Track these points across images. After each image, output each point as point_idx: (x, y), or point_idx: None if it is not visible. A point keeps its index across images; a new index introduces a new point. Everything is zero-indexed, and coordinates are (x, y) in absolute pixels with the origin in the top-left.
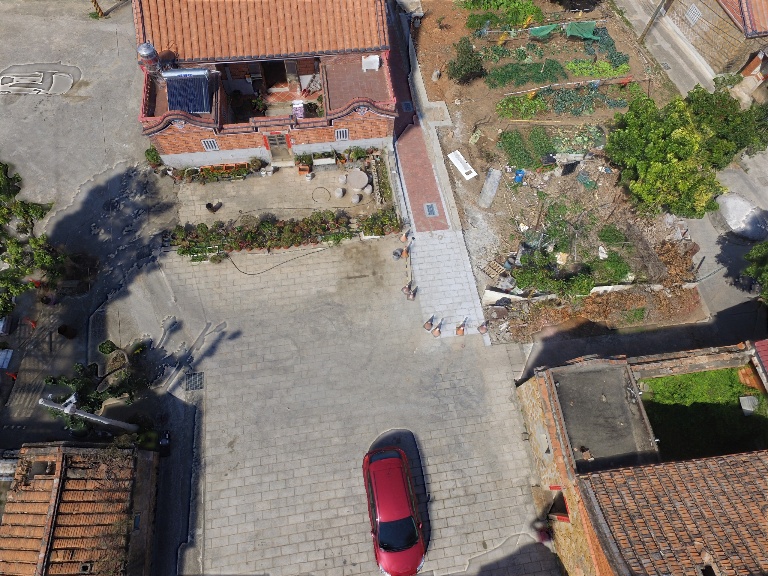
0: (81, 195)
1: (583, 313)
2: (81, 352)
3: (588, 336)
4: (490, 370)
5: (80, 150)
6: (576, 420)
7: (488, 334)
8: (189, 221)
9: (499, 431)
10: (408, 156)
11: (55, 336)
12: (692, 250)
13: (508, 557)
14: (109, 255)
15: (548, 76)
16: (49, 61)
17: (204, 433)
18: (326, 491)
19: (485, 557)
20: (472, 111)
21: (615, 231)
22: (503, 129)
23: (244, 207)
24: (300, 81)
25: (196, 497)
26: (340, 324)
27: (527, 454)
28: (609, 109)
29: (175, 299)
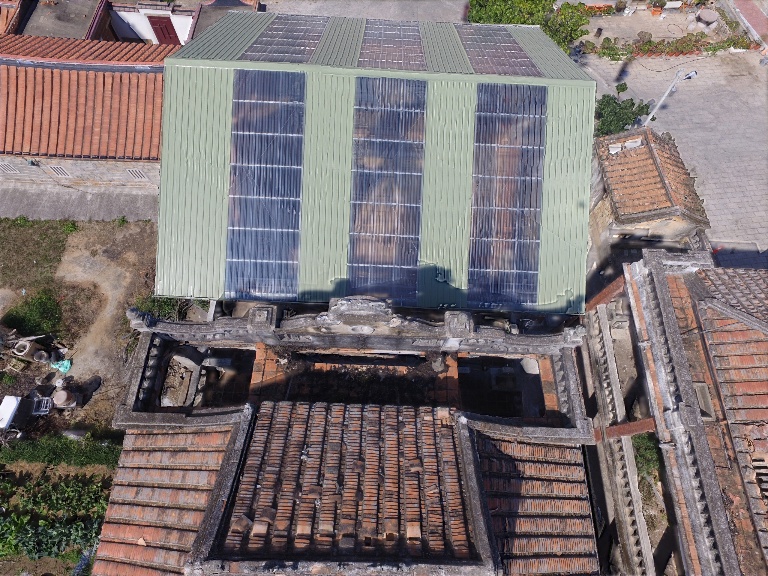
0: None
1: None
2: None
3: None
4: None
5: None
6: None
7: None
8: None
9: None
10: (739, 2)
11: None
12: None
13: None
14: None
15: None
16: None
17: None
18: None
19: None
20: None
21: None
22: None
23: (619, 35)
24: None
25: None
26: (739, 103)
27: None
28: None
29: (608, 84)
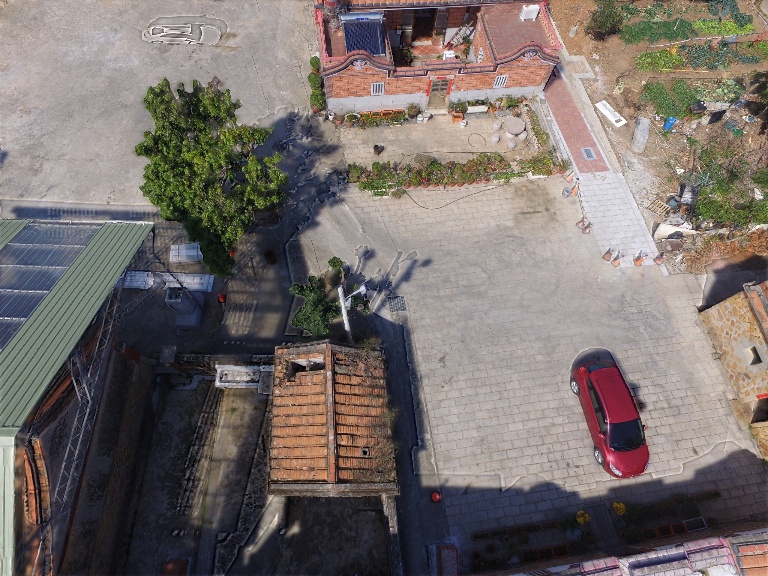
0: None
1: (750, 247)
2: (284, 276)
3: (756, 269)
4: (672, 297)
5: (240, 96)
6: None
7: (664, 265)
8: (356, 162)
9: (690, 351)
10: (557, 105)
11: (256, 262)
12: None
13: (719, 462)
14: (290, 191)
15: (680, 33)
16: (194, 14)
17: (415, 350)
18: (539, 402)
19: (697, 461)
20: (611, 65)
21: None
22: (645, 81)
23: (406, 151)
24: (445, 34)
25: (419, 406)
26: (524, 254)
27: (720, 372)
28: (741, 65)
29: (363, 230)
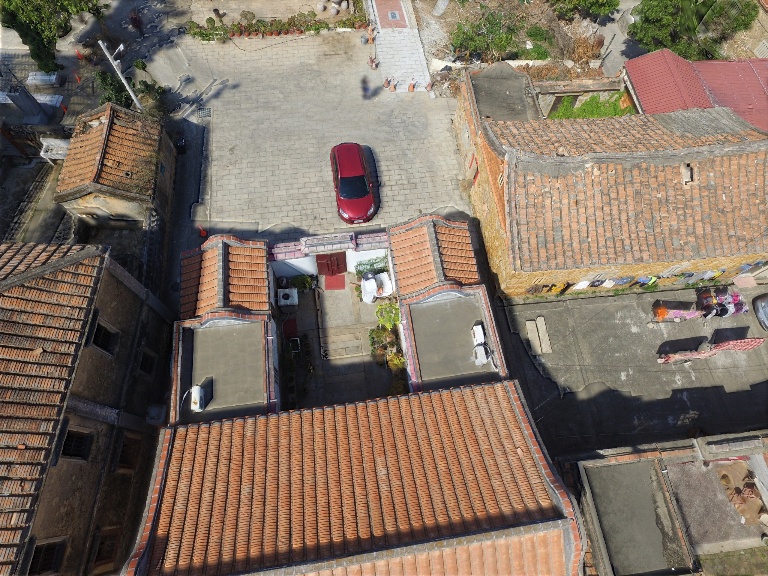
0: (113, 4)
1: None
2: None
3: None
4: (433, 113)
5: None
6: (485, 102)
7: (433, 91)
8: (200, 24)
9: (437, 148)
10: None
11: (96, 84)
12: (599, 39)
13: None
14: (136, 39)
15: None
16: None
17: (211, 142)
18: (303, 178)
19: None
20: None
21: (540, 29)
22: None
23: None
24: None
25: (205, 178)
26: (317, 82)
27: (457, 162)
28: None
29: (189, 65)
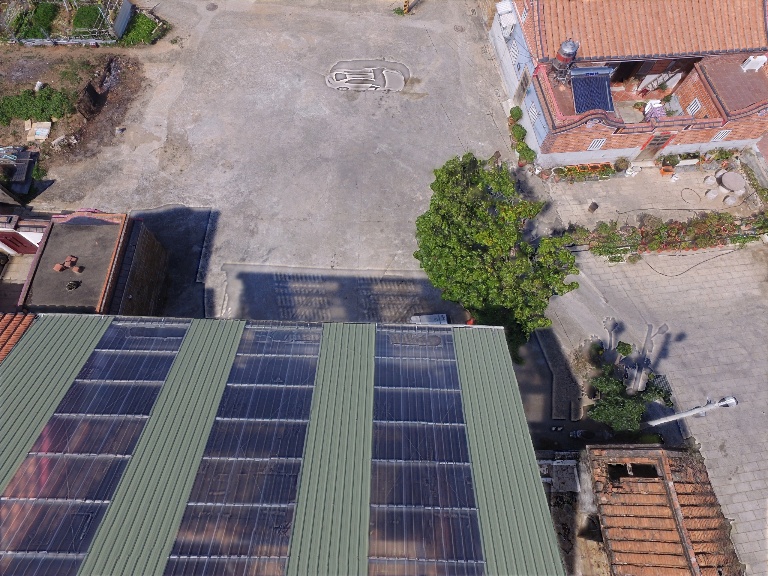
0: None
1: None
2: (536, 352)
3: None
4: None
5: (439, 148)
6: None
7: None
8: (571, 221)
9: None
10: None
11: None
12: None
13: None
14: None
15: None
16: (373, 57)
17: None
18: None
19: None
20: None
21: None
22: None
23: (619, 207)
24: (642, 80)
25: None
26: None
27: None
28: None
29: (606, 300)
